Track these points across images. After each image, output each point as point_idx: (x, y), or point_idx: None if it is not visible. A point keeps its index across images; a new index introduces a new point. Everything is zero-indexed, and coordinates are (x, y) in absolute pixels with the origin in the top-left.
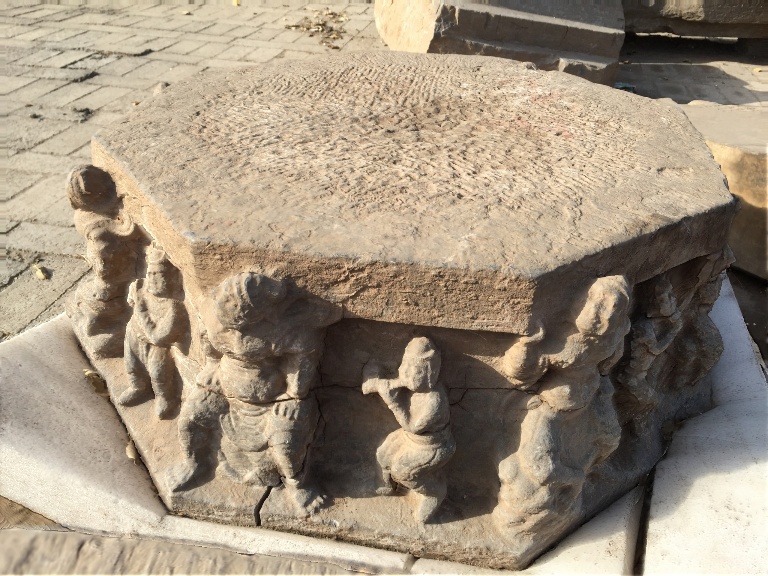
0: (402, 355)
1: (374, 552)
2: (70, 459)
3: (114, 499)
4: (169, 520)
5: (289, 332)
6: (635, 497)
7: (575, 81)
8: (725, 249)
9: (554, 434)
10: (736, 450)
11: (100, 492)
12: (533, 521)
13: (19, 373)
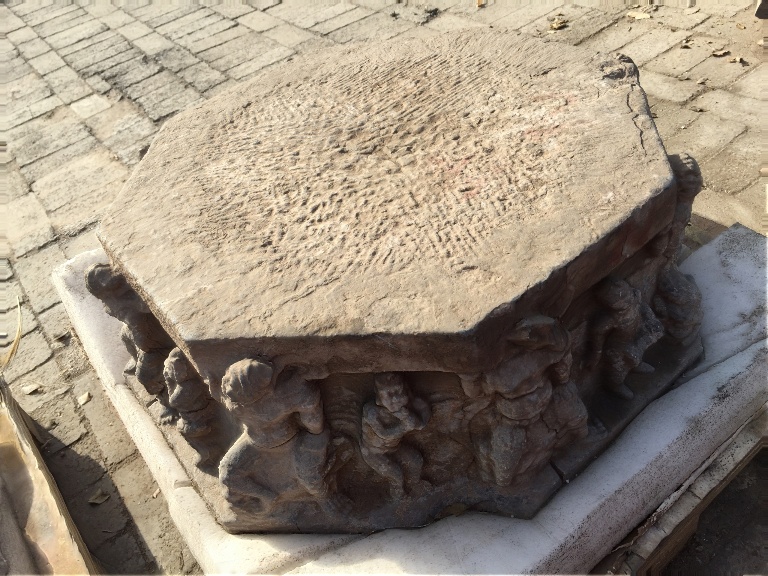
0: None
1: (173, 467)
2: (102, 329)
3: (102, 362)
4: (119, 387)
5: (122, 309)
6: (353, 541)
7: (617, 109)
8: (488, 374)
9: (244, 456)
10: (443, 560)
11: (99, 355)
12: (228, 506)
13: None
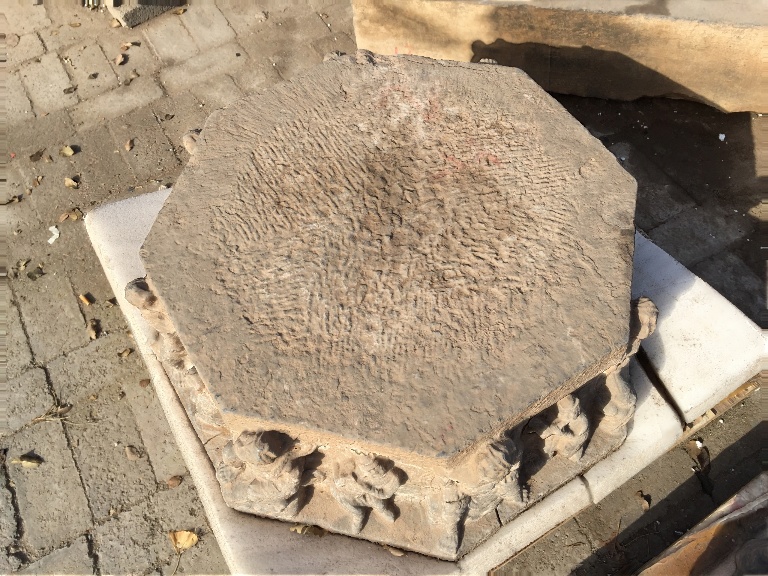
0: (554, 407)
1: (566, 491)
2: None
3: None
4: (463, 566)
5: None
6: (633, 355)
7: (427, 70)
8: None
9: (625, 380)
10: (661, 296)
11: None
12: None
13: (282, 575)
